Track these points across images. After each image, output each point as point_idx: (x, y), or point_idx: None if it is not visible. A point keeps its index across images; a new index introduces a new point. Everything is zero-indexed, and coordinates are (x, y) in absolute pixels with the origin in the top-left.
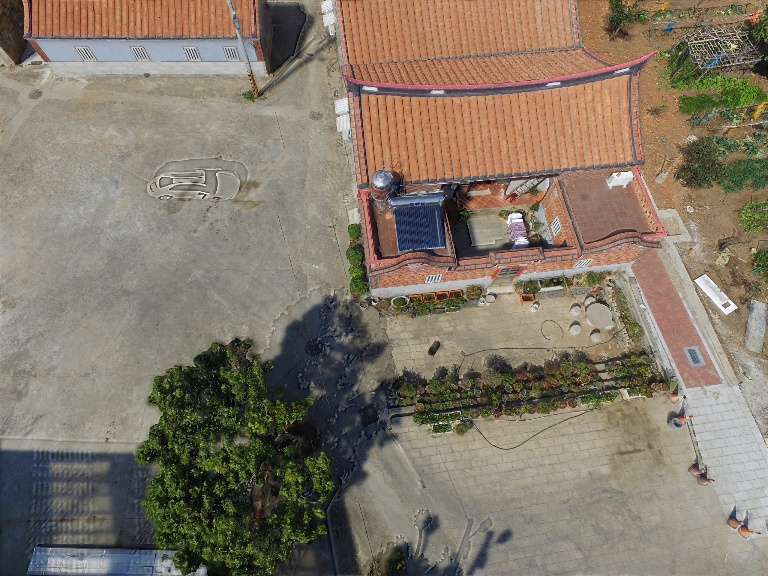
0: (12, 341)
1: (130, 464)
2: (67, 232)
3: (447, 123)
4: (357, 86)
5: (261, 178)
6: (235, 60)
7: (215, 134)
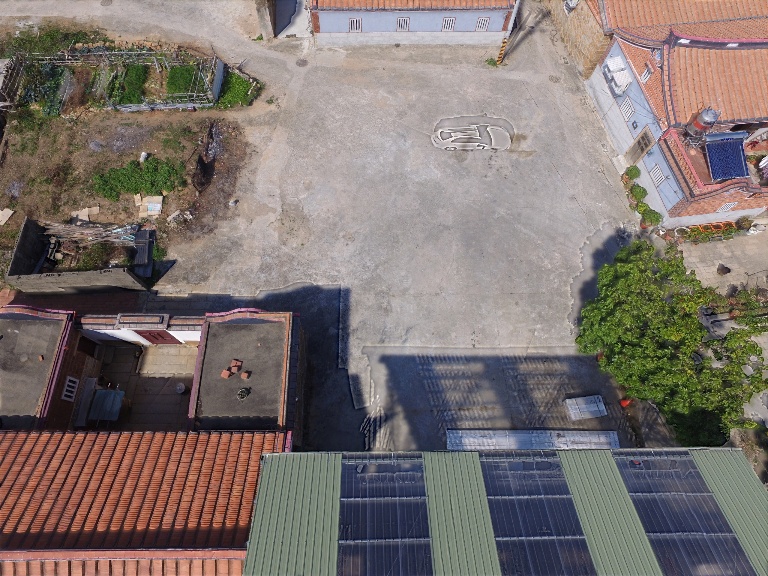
0: (363, 268)
1: (500, 365)
2: (376, 178)
3: (738, 72)
4: (676, 39)
5: (526, 132)
6: (482, 30)
7: (474, 95)
